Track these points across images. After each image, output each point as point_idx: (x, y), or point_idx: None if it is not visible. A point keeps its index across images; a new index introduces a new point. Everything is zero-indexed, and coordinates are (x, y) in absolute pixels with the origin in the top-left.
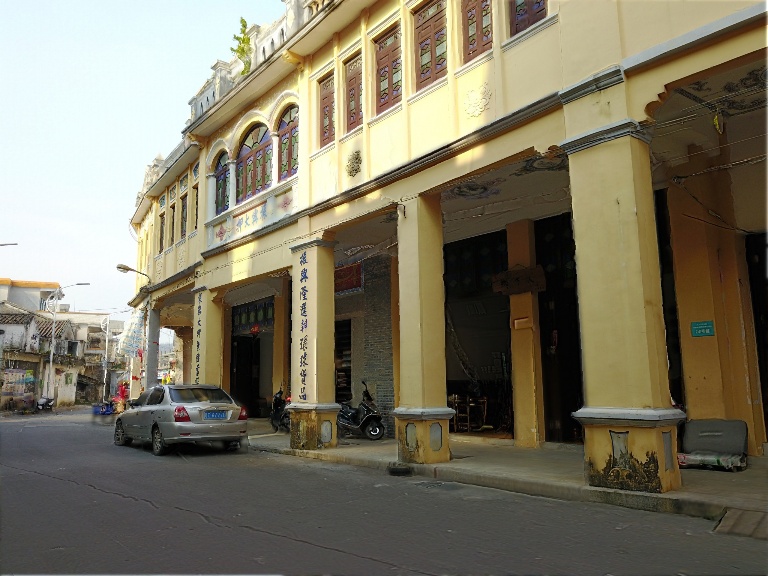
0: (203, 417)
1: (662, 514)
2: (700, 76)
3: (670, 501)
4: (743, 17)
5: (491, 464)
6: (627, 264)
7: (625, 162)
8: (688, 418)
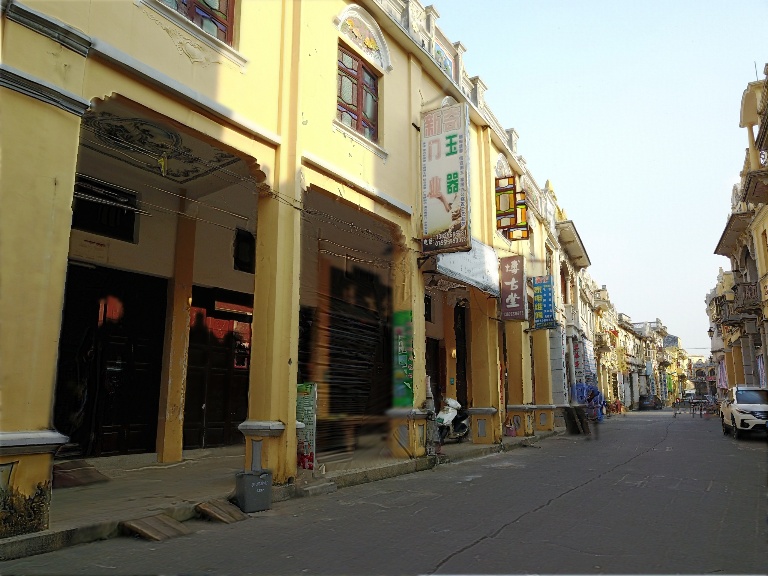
0: None
1: (64, 550)
2: (133, 106)
3: (68, 533)
4: (185, 92)
5: None
6: (53, 258)
7: (72, 143)
8: None
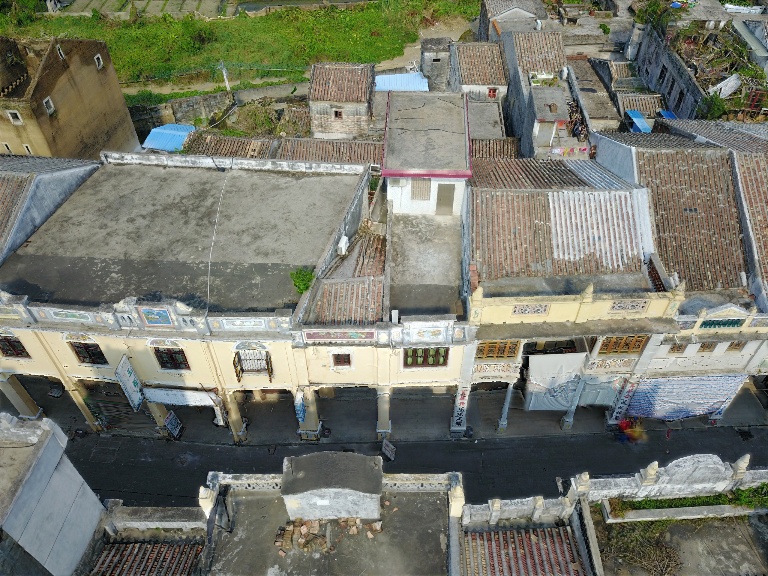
0: None
1: None
2: None
3: None
4: None
5: (2, 408)
6: None
7: None
8: (50, 380)
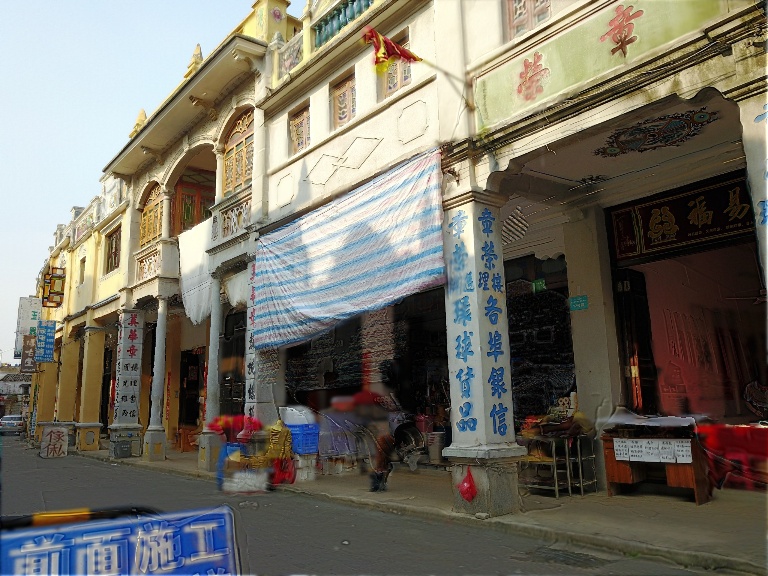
0: (6, 425)
1: None
2: None
3: None
4: None
5: None
6: None
7: None
8: None
